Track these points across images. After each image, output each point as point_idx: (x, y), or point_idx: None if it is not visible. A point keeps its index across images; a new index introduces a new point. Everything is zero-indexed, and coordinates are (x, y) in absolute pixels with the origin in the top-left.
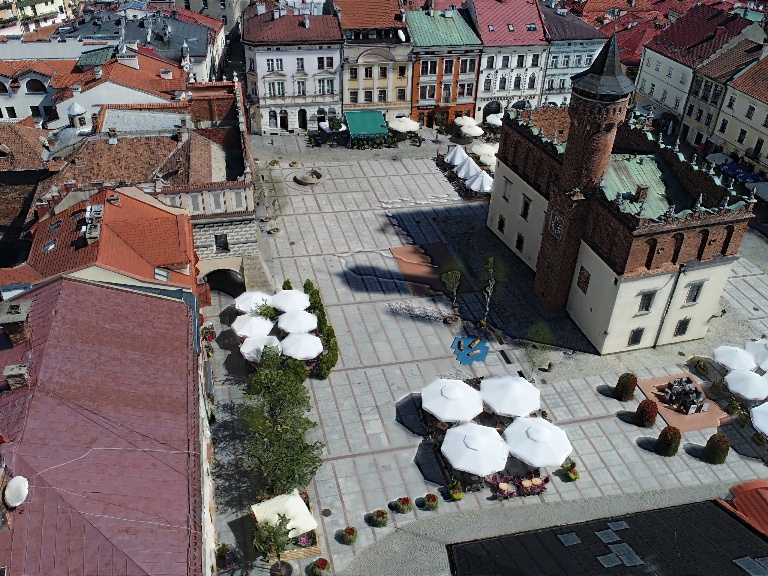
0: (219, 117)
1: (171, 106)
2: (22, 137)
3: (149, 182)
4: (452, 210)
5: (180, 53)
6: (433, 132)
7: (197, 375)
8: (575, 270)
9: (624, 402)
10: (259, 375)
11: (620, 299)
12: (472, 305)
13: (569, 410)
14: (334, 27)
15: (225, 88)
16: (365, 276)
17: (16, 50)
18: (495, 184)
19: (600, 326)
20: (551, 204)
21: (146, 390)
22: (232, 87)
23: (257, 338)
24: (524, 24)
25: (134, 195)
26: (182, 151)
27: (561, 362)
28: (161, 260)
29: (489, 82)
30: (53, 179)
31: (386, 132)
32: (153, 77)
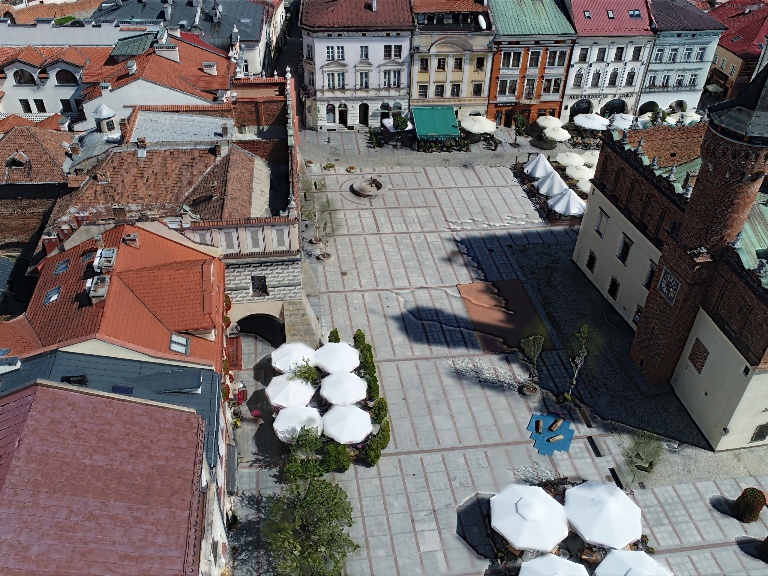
0: (267, 122)
1: (212, 109)
2: (42, 143)
3: (175, 216)
4: (531, 236)
5: (228, 40)
6: (511, 133)
7: (200, 535)
8: (687, 340)
9: (746, 524)
10: (294, 459)
11: (749, 392)
12: (553, 368)
13: (675, 531)
14: (405, 10)
15: (276, 85)
16: (426, 322)
17: (46, 35)
18: (587, 214)
19: (717, 417)
20: (664, 259)
21: (126, 571)
22: (284, 84)
23: (294, 411)
24: (626, 10)
25: (157, 230)
26: (219, 169)
27: (664, 458)
28: (180, 324)
29: (580, 77)
30: (72, 197)
31: (458, 133)
32: (195, 71)
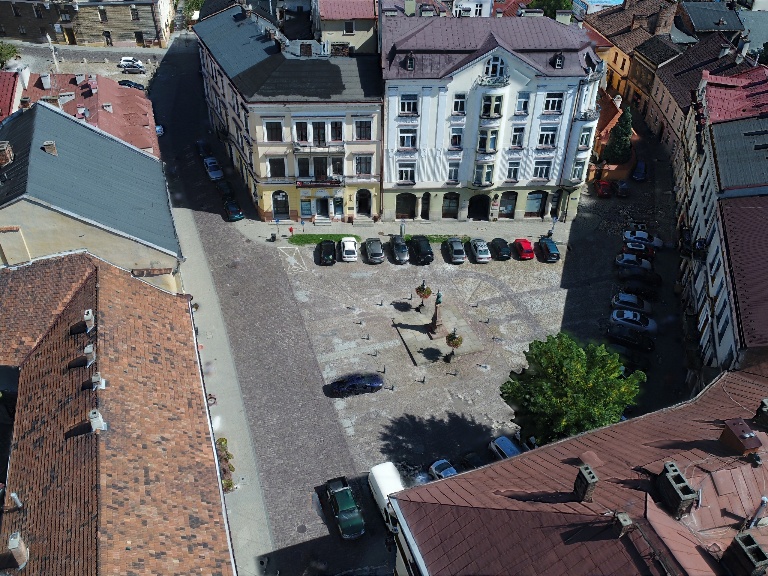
0: None
1: None
2: None
3: None
4: None
5: None
6: None
7: None
8: None
9: None
10: None
11: None
12: None
13: None
14: None
15: None
16: None
17: None
18: None
19: None
20: None
21: None
22: None
23: None
24: None
25: None
26: None
27: None
28: None
29: None
30: None
31: None
32: None
